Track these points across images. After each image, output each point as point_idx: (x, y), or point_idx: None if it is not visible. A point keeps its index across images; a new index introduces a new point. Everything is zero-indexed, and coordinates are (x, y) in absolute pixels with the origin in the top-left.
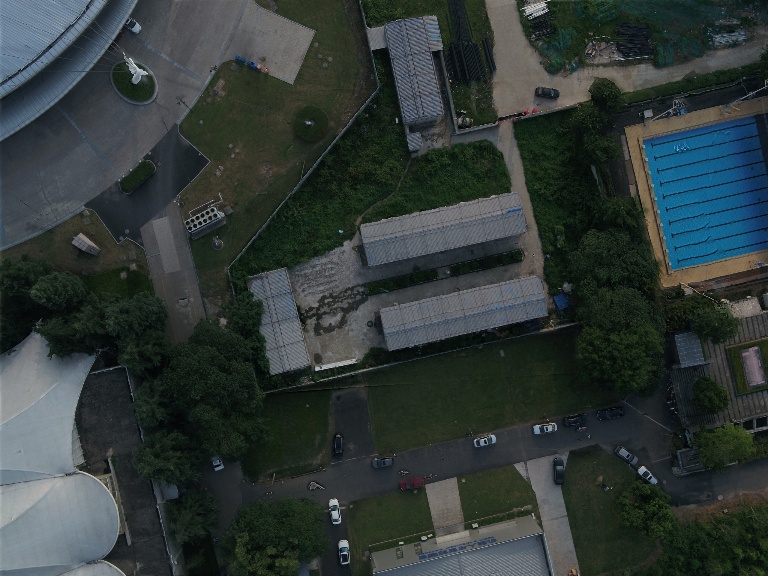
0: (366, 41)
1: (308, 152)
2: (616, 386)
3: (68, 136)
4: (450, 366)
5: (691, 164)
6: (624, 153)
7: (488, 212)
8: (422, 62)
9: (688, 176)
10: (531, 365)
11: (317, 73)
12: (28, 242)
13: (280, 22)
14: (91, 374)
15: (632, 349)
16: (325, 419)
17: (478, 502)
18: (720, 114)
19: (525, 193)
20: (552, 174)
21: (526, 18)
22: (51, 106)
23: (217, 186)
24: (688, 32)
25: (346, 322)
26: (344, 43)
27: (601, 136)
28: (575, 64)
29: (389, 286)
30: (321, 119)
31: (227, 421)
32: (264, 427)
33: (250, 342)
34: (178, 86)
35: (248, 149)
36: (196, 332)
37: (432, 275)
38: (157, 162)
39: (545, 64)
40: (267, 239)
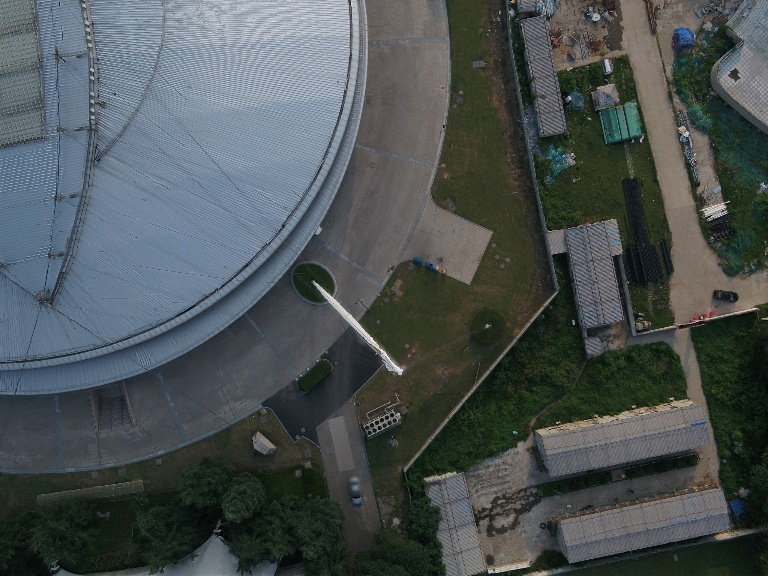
0: (543, 242)
1: (484, 353)
2: None
3: (247, 335)
4: (623, 570)
5: None
6: None
7: (672, 425)
8: (603, 268)
9: None
10: (705, 570)
11: (494, 274)
12: (206, 440)
13: (458, 222)
14: None
15: None
16: None
17: None
18: None
19: (701, 396)
20: (729, 378)
21: (705, 220)
22: (240, 316)
23: (393, 386)
24: None
25: (519, 524)
26: (521, 244)
27: None
28: (754, 266)
29: (564, 490)
30: (499, 322)
31: None
32: None
33: (428, 549)
34: (356, 286)
35: (424, 349)
36: (383, 549)
37: (607, 479)
38: (334, 361)
39: (723, 266)
40: (442, 440)
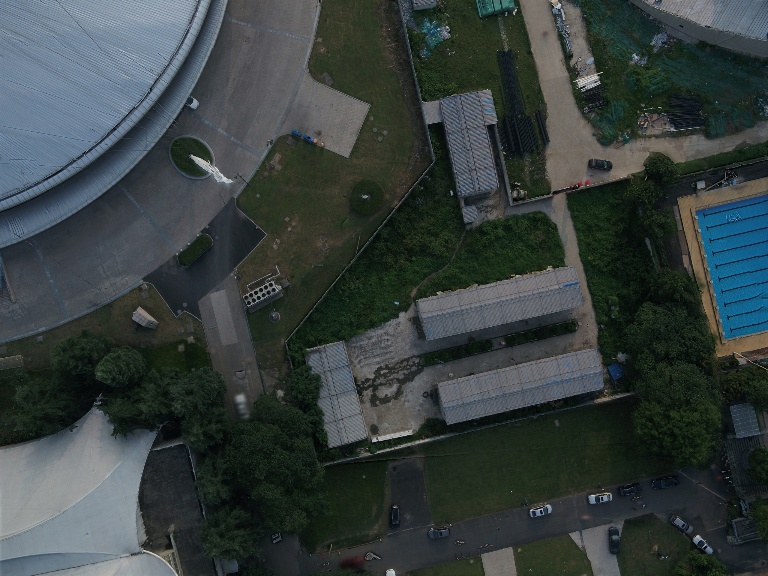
0: (421, 114)
1: (364, 225)
2: (675, 461)
3: (127, 211)
4: (505, 436)
5: (743, 233)
6: (677, 224)
7: (545, 286)
8: (477, 136)
9: (740, 245)
10: (586, 435)
11: (372, 146)
12: (87, 316)
13: (336, 96)
14: (153, 450)
15: (693, 427)
16: (381, 490)
17: (534, 572)
18: None
19: (579, 264)
20: (605, 245)
21: (579, 90)
22: (113, 185)
23: (274, 259)
24: (739, 103)
25: (402, 393)
26: (399, 116)
27: (657, 211)
28: (627, 135)
29: (445, 358)
30: (377, 192)
31: (289, 498)
32: (324, 502)
33: (309, 416)
34: (235, 160)
35: (304, 222)
36: (258, 410)
37: (487, 346)
38: (214, 236)
39: (598, 136)
40: (324, 311)
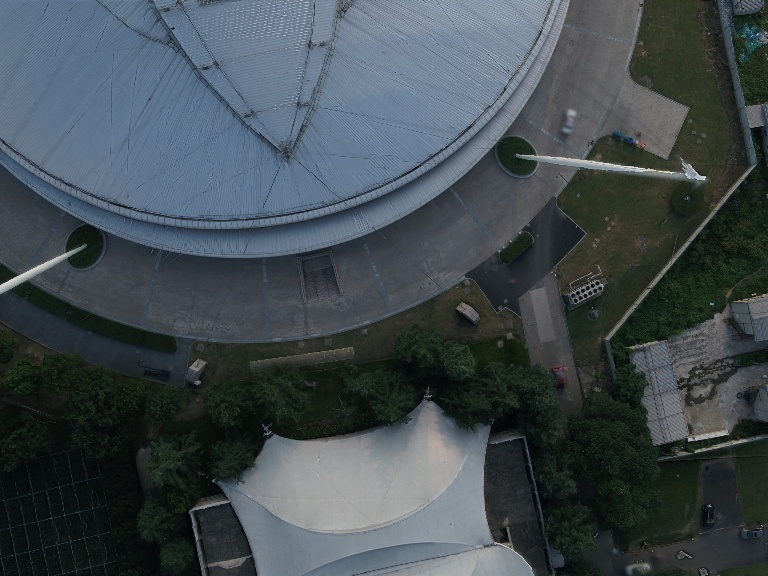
0: (738, 118)
1: (681, 226)
2: None
3: (452, 208)
4: None
5: None
6: None
7: None
8: None
9: None
10: None
11: (691, 149)
12: (410, 310)
13: (655, 99)
14: (490, 444)
15: None
16: (694, 489)
17: None
18: None
19: None
20: None
21: None
22: (455, 182)
23: (593, 258)
24: None
25: (716, 393)
26: (717, 120)
27: None
28: None
29: (762, 359)
30: (698, 194)
31: None
32: (658, 500)
33: None
34: None
35: (624, 222)
36: (602, 406)
37: None
38: (535, 234)
39: None
40: (642, 311)
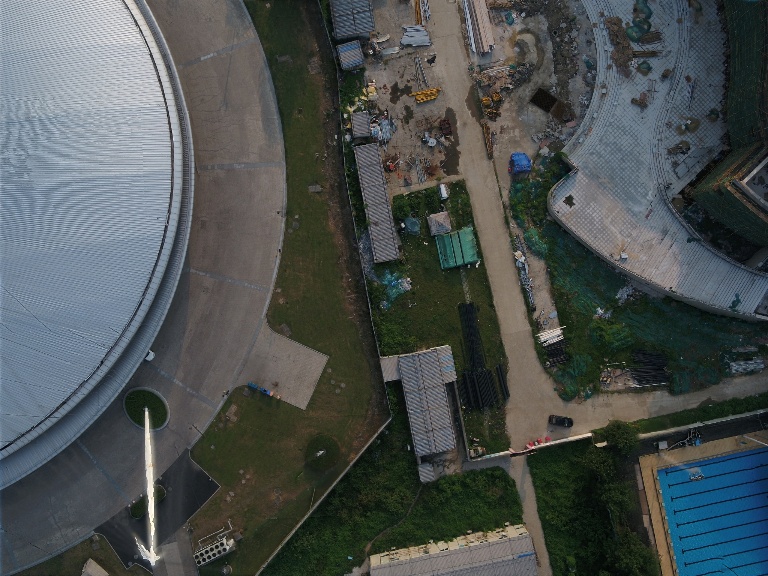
0: (379, 367)
1: (319, 478)
2: None
3: (79, 461)
4: None
5: (706, 492)
6: (638, 483)
7: (499, 557)
8: (435, 396)
9: (702, 504)
10: None
11: (329, 399)
12: (37, 567)
13: (293, 347)
14: None
15: None
16: None
17: None
18: (736, 445)
19: (537, 520)
20: (564, 503)
21: (541, 345)
22: (63, 449)
23: (227, 512)
24: (705, 359)
25: None
26: (357, 369)
27: (615, 484)
28: (590, 391)
29: None
30: (333, 448)
31: None
32: None
33: None
34: (190, 411)
35: (259, 475)
36: None
37: None
38: (168, 487)
39: (559, 391)
40: (276, 566)
